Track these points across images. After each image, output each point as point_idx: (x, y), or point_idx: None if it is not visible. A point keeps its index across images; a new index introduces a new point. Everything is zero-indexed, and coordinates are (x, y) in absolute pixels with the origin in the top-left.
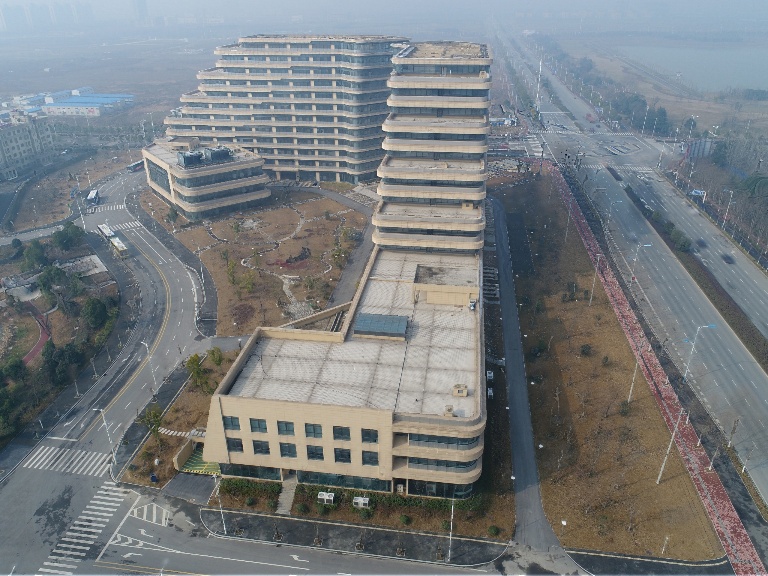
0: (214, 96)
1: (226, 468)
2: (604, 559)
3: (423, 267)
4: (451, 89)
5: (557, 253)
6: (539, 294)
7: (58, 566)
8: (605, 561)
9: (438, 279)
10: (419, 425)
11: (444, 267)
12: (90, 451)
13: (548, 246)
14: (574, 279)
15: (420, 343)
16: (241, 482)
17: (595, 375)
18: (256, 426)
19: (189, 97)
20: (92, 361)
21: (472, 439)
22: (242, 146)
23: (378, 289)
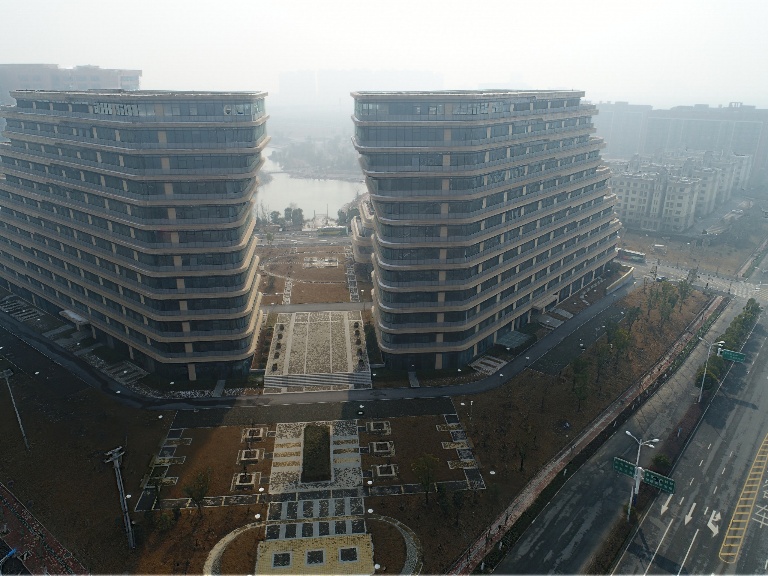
0: None
1: None
2: None
3: None
4: None
5: None
6: None
7: None
8: None
9: None
10: None
11: None
12: None
13: None
14: None
15: None
16: None
17: None
18: None
19: None
20: None
21: None
22: None
23: None
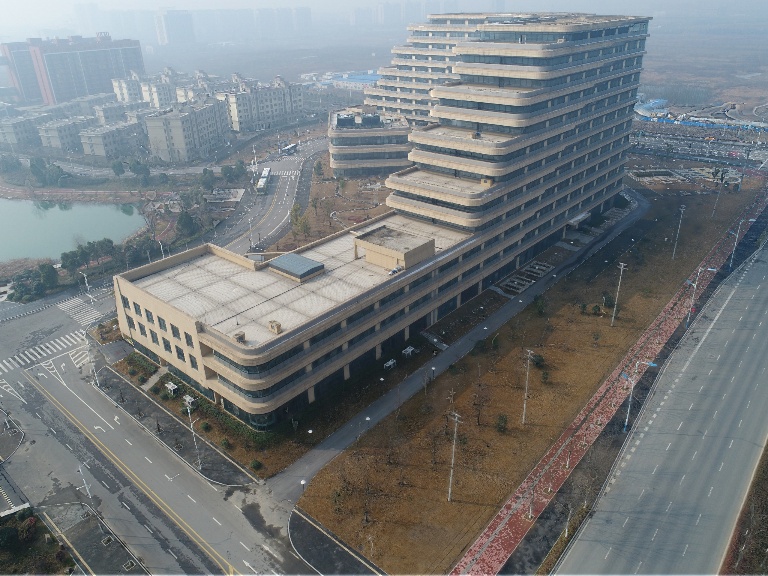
0: (402, 70)
1: (135, 343)
2: (315, 531)
3: (388, 229)
4: (511, 57)
5: (644, 267)
6: (565, 300)
7: (7, 365)
8: (313, 533)
9: (383, 240)
10: (213, 340)
11: (405, 232)
12: (95, 309)
13: (643, 259)
14: (628, 296)
15: (309, 287)
16: (139, 357)
17: (520, 387)
18: (138, 310)
19: (383, 70)
20: (148, 253)
21: (255, 370)
22: (418, 119)
23: (344, 241)
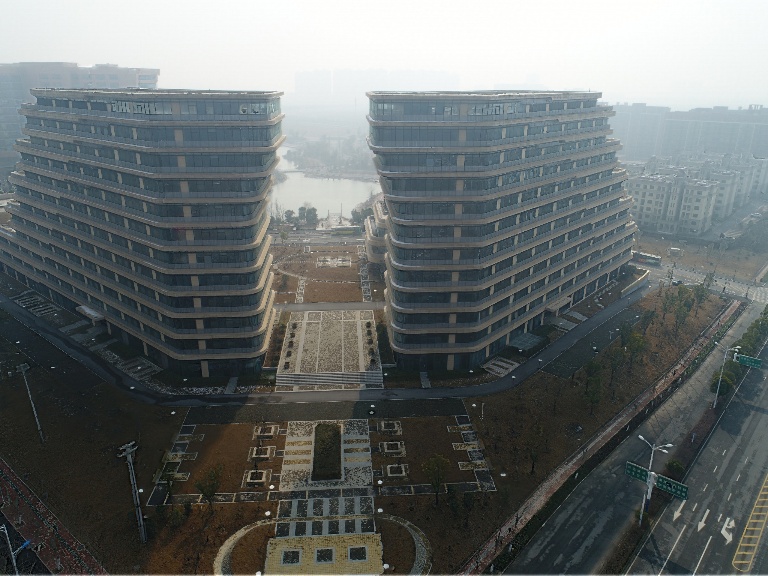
0: None
1: None
2: None
3: None
4: None
5: None
6: None
7: None
8: None
9: None
10: None
11: None
12: None
13: None
14: None
15: None
16: None
17: None
18: None
19: None
20: None
21: None
22: None
23: None
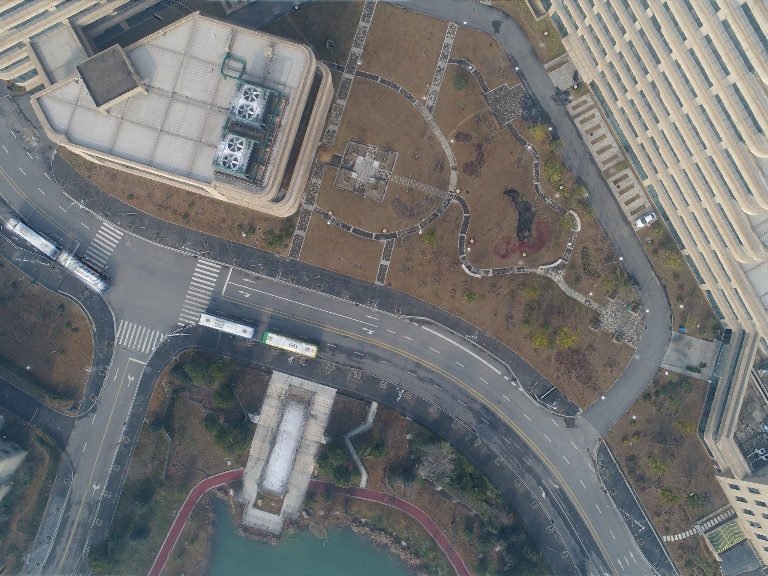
0: None
1: None
2: None
3: None
4: None
5: None
6: None
7: None
8: None
9: None
10: None
11: None
12: None
13: None
14: None
15: None
16: None
17: None
18: None
19: None
20: None
21: None
22: None
23: None
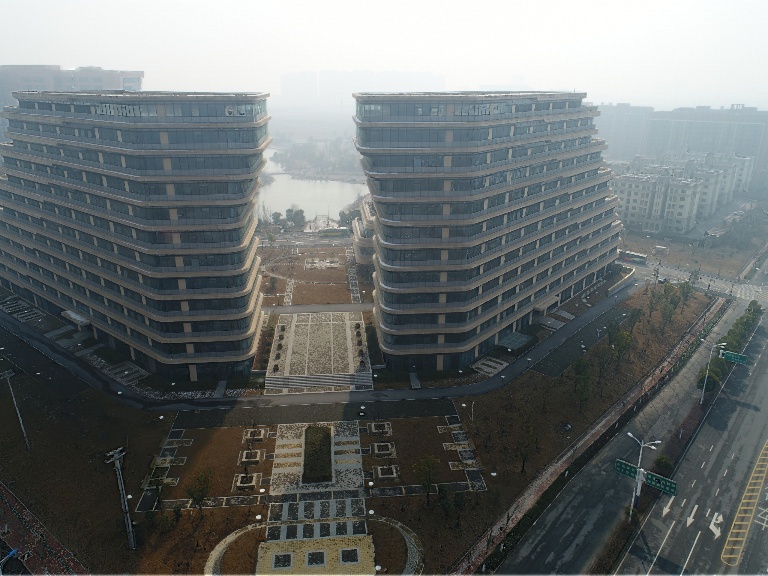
0: None
1: None
2: None
3: None
4: None
5: None
6: None
7: None
8: None
9: None
10: None
11: None
12: None
13: None
14: None
15: None
16: None
17: None
18: None
19: None
20: None
21: None
22: None
23: None
